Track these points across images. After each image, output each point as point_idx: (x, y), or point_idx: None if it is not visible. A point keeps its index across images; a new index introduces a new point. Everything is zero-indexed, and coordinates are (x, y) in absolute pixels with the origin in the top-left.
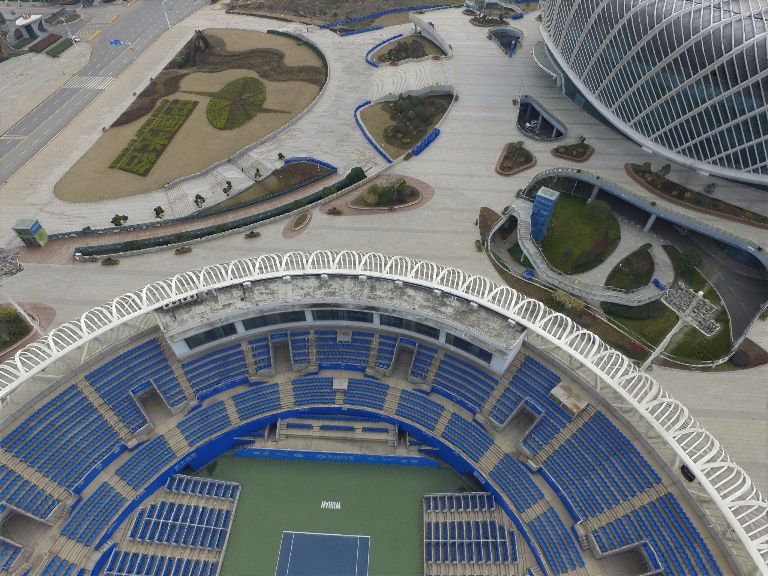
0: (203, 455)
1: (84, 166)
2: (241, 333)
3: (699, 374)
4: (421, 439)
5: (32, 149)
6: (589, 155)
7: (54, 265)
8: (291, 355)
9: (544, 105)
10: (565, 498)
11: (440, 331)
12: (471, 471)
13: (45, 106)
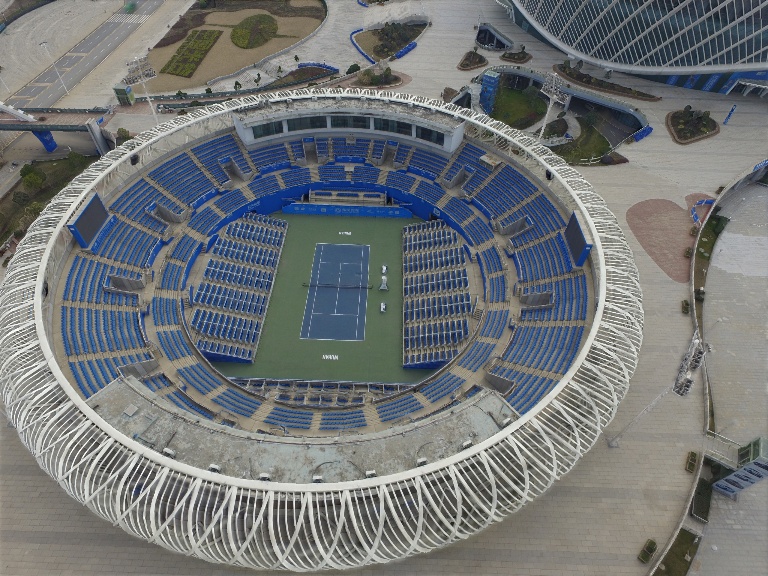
0: (263, 206)
1: None
2: (285, 133)
3: (580, 167)
4: (401, 200)
5: (94, 62)
6: (528, 59)
7: (143, 115)
8: (317, 151)
9: None
10: (485, 209)
11: (412, 127)
12: (432, 211)
13: (96, 34)
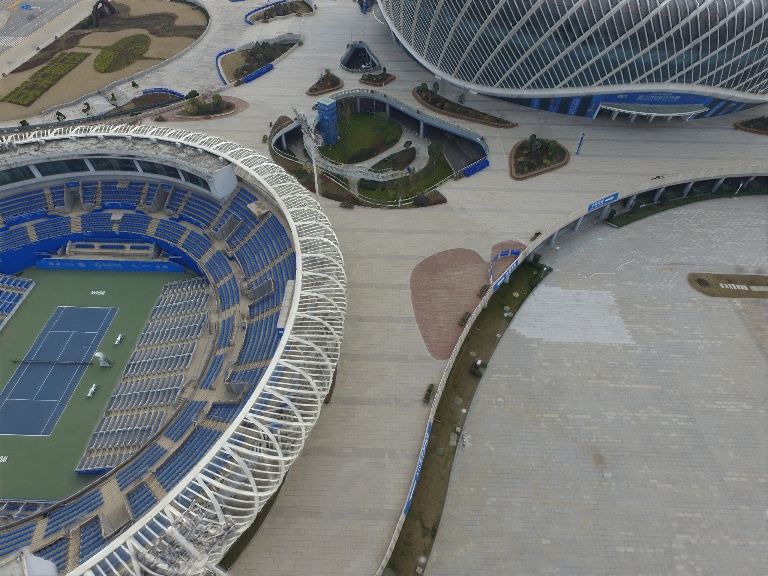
0: (8, 262)
1: None
2: (39, 178)
3: (387, 210)
4: (171, 252)
5: None
6: (388, 81)
7: None
8: (81, 197)
9: (373, 48)
10: None
11: (177, 170)
12: (197, 266)
13: None
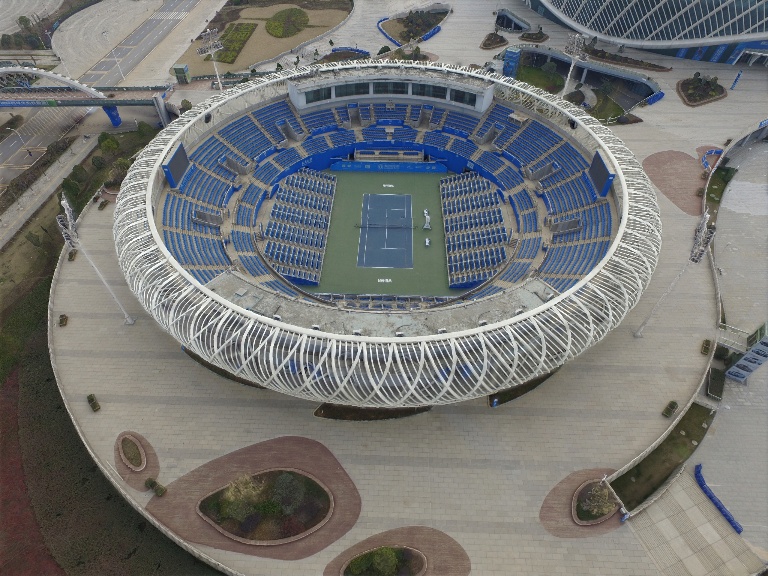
0: (315, 163)
1: (186, 60)
2: (333, 99)
3: None
4: (437, 156)
5: (143, 53)
6: (545, 39)
7: (200, 91)
8: None
9: None
10: (515, 159)
11: (447, 90)
12: (466, 165)
13: (141, 29)
